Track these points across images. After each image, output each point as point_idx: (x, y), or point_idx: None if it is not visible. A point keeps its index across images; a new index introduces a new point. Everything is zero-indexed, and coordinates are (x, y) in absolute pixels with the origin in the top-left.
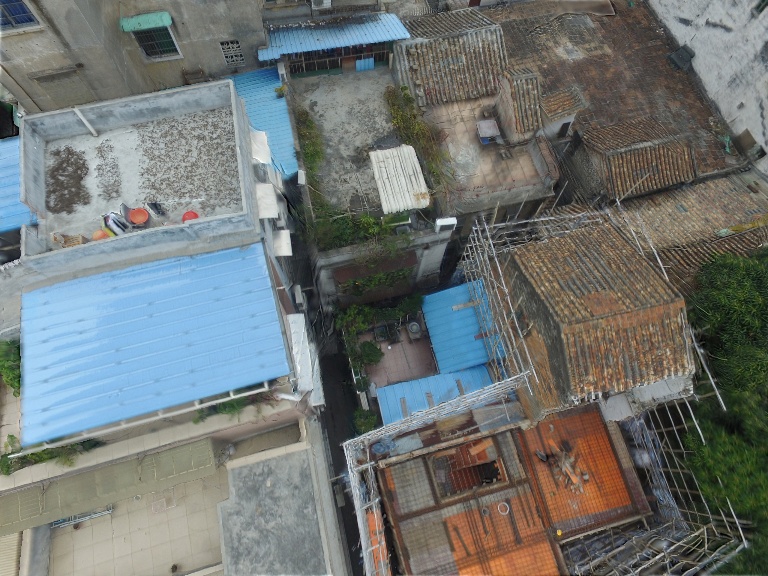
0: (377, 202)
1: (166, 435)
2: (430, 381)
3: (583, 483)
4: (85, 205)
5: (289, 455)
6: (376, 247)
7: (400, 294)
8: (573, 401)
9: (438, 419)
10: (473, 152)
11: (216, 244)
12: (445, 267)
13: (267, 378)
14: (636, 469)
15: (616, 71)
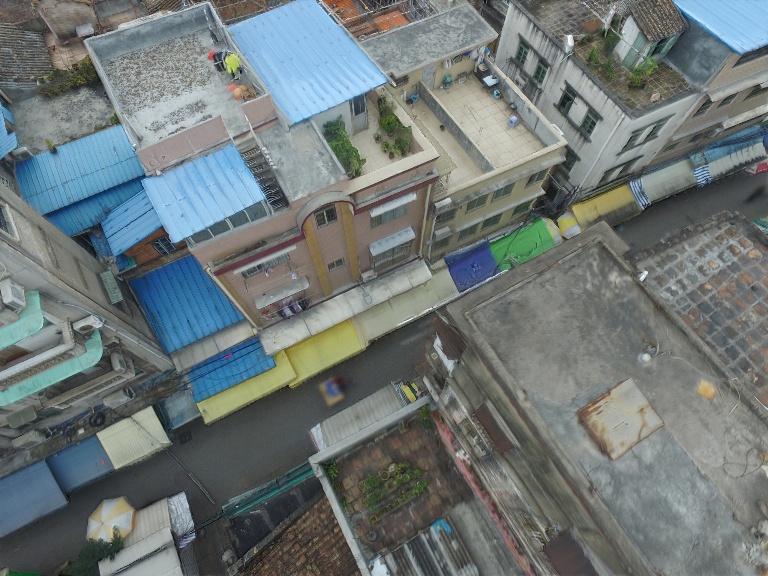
0: None
1: None
2: None
3: (338, 7)
4: None
5: None
6: None
7: None
8: None
9: None
10: None
11: None
12: None
13: (316, 3)
14: None
15: (2, 11)
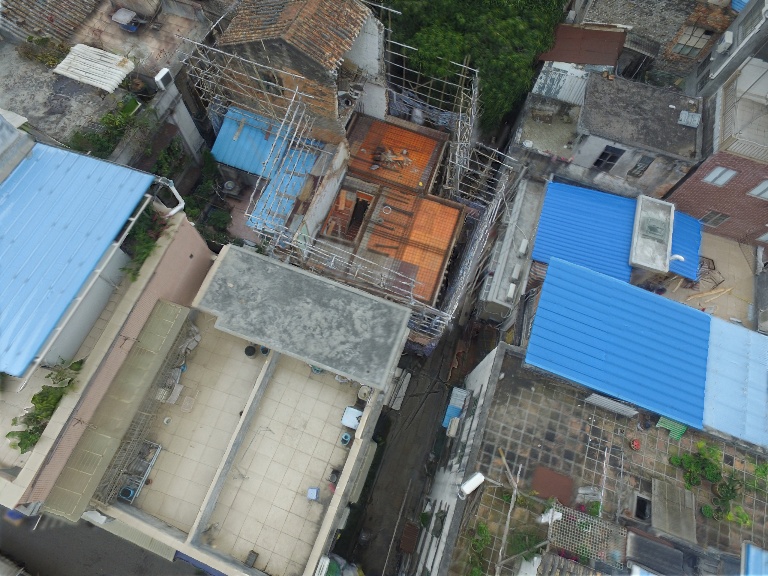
0: (97, 91)
1: (124, 306)
2: (270, 188)
3: (407, 156)
4: None
5: (224, 261)
6: (135, 131)
7: (197, 178)
8: (334, 75)
9: (296, 194)
10: (133, 42)
11: (4, 169)
12: (205, 137)
13: (143, 191)
14: (422, 125)
15: None
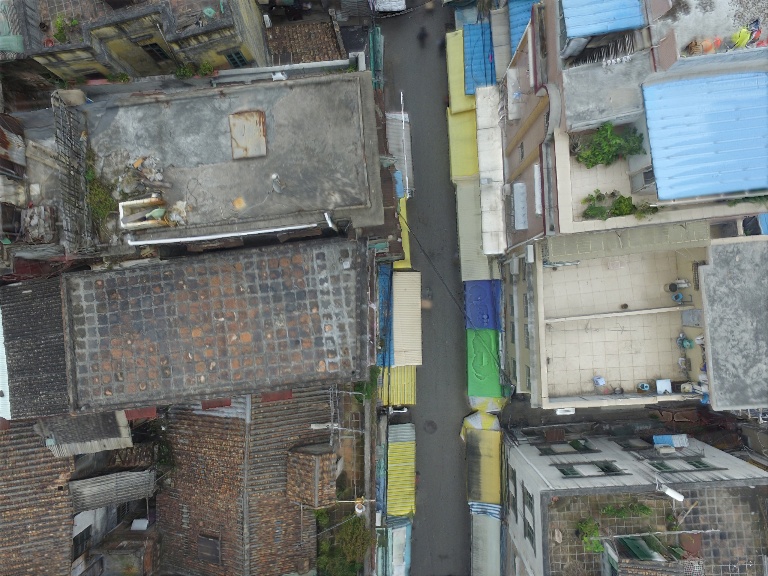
0: None
1: (708, 211)
2: None
3: None
4: (686, 16)
5: (754, 243)
6: None
7: None
8: None
9: None
10: None
11: None
12: None
13: None
14: None
15: None
